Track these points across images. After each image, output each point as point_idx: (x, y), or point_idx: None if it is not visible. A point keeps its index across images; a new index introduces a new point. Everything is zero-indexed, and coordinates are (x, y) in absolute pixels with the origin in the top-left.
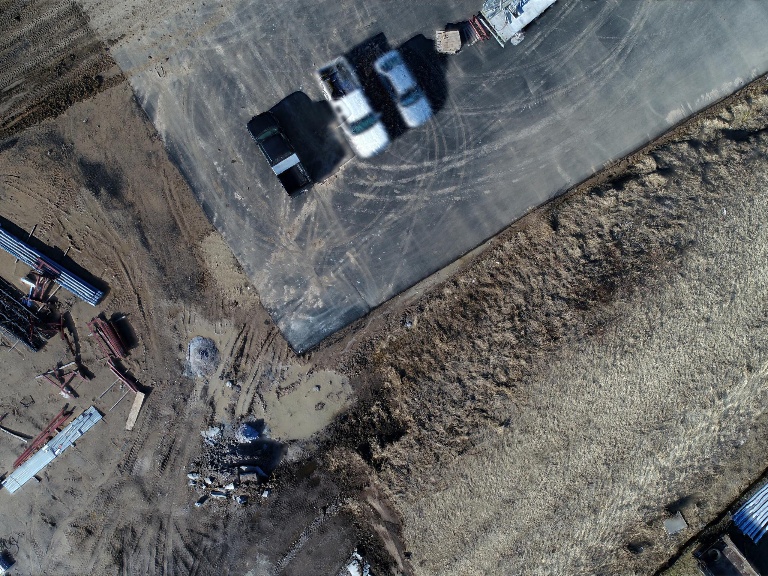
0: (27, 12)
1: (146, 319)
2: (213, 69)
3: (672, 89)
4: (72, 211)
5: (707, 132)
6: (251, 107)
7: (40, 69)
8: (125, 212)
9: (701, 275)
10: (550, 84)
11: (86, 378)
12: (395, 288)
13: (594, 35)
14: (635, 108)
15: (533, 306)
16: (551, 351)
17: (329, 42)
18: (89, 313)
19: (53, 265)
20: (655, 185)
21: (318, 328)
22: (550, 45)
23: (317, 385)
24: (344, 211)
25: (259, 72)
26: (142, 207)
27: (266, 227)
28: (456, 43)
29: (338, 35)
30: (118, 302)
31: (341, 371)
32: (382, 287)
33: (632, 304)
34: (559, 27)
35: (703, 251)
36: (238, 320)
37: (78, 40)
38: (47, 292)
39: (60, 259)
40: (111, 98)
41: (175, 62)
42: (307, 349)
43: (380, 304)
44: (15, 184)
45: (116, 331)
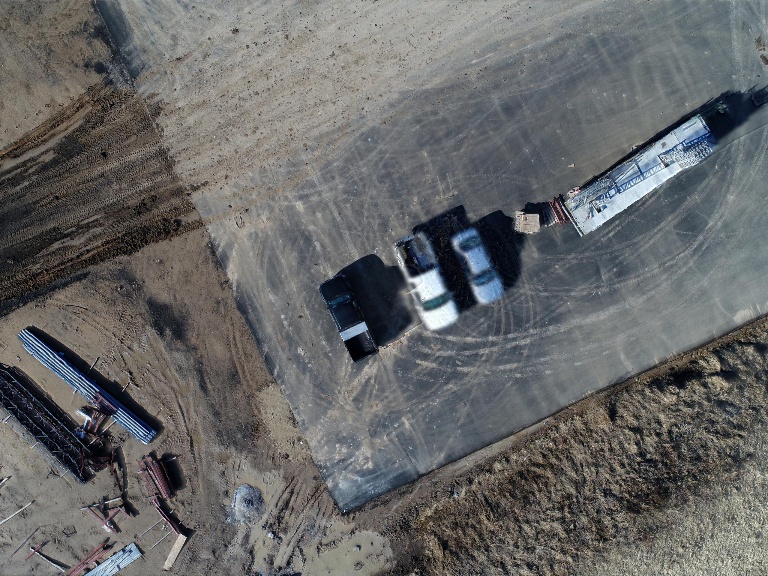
0: (114, 149)
1: (196, 462)
2: (291, 224)
3: (743, 289)
4: (135, 348)
5: None
6: (324, 265)
7: (120, 206)
8: (187, 354)
9: (756, 490)
10: (622, 272)
11: (130, 515)
12: (446, 457)
13: (671, 228)
14: (704, 304)
15: (584, 499)
16: (599, 553)
17: (408, 209)
18: (141, 450)
19: (111, 401)
20: (718, 388)
21: (366, 489)
22: (627, 234)
23: (358, 545)
24: (404, 376)
25: (336, 232)
26: (205, 351)
27: (325, 384)
28: (535, 226)
29: (418, 203)
30: (170, 442)
31: (384, 534)
32: (434, 455)
33: (685, 514)
34: (637, 217)
35: (760, 466)
36: (287, 472)
37: (161, 182)
38: (101, 425)
39: (118, 394)
40: (187, 242)
41: (254, 213)
42: (352, 509)
43: (430, 471)
44: (82, 316)
45: (166, 472)
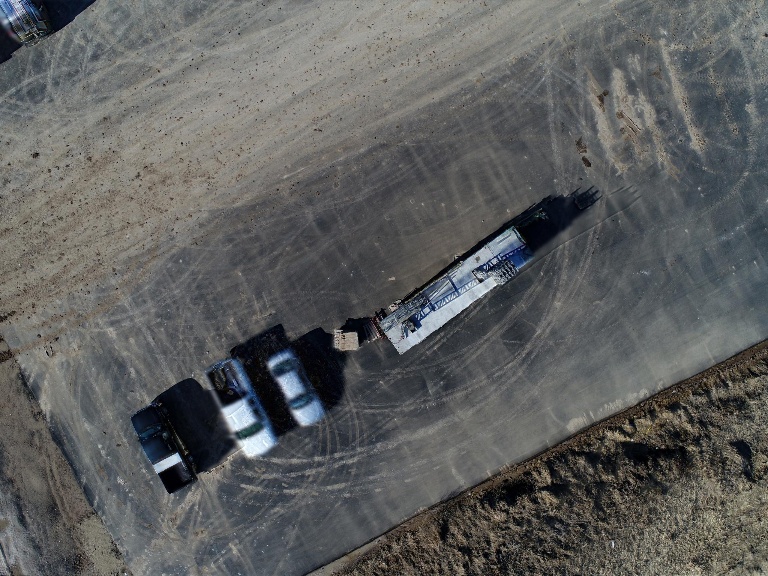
0: None
1: None
2: (103, 351)
3: (575, 397)
4: None
5: (607, 444)
6: (140, 391)
7: None
8: (4, 488)
9: None
10: (450, 385)
11: None
12: None
13: (498, 338)
14: (536, 414)
15: None
16: None
17: (225, 330)
18: None
19: None
20: (547, 504)
21: None
22: (452, 346)
23: None
24: (229, 501)
25: (151, 357)
26: (22, 484)
27: (148, 513)
28: (353, 344)
29: (235, 324)
30: None
31: None
32: None
33: None
34: (463, 328)
35: None
36: None
37: None
38: None
39: None
40: None
41: (65, 342)
42: None
43: None
44: None
45: None
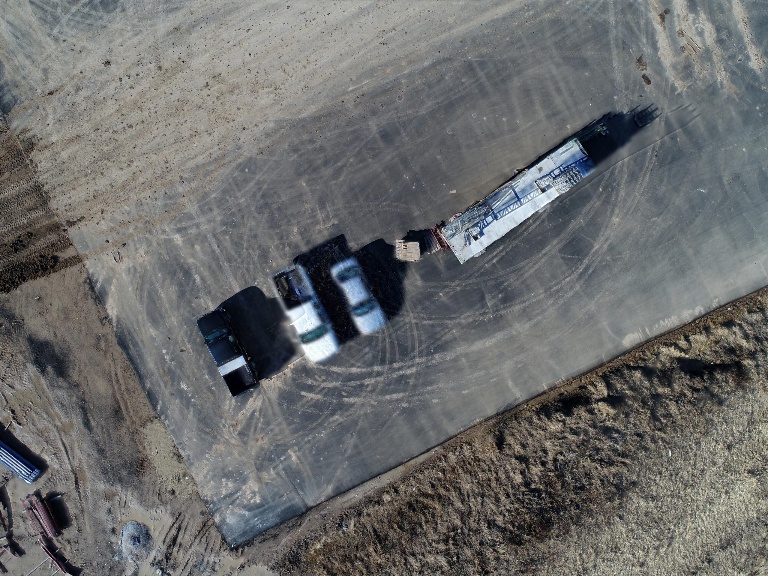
0: None
1: (81, 499)
2: (169, 258)
3: (631, 312)
4: (17, 386)
5: (663, 359)
6: (205, 298)
7: None
8: (70, 391)
9: (640, 518)
10: (508, 298)
11: (16, 555)
12: (334, 489)
13: (556, 253)
14: (592, 328)
15: (469, 530)
16: None
17: (288, 240)
18: (25, 489)
19: None
20: (604, 414)
21: (253, 523)
22: (511, 259)
23: None
24: (289, 409)
25: (215, 264)
26: (87, 388)
27: (210, 418)
28: (415, 254)
29: (298, 233)
30: (55, 480)
31: (273, 568)
32: (321, 487)
33: (567, 544)
34: (522, 242)
35: (644, 493)
36: (174, 508)
37: (37, 218)
38: None
39: (0, 433)
40: (65, 278)
41: (132, 248)
42: (240, 543)
43: (318, 504)
44: None
45: (50, 511)
